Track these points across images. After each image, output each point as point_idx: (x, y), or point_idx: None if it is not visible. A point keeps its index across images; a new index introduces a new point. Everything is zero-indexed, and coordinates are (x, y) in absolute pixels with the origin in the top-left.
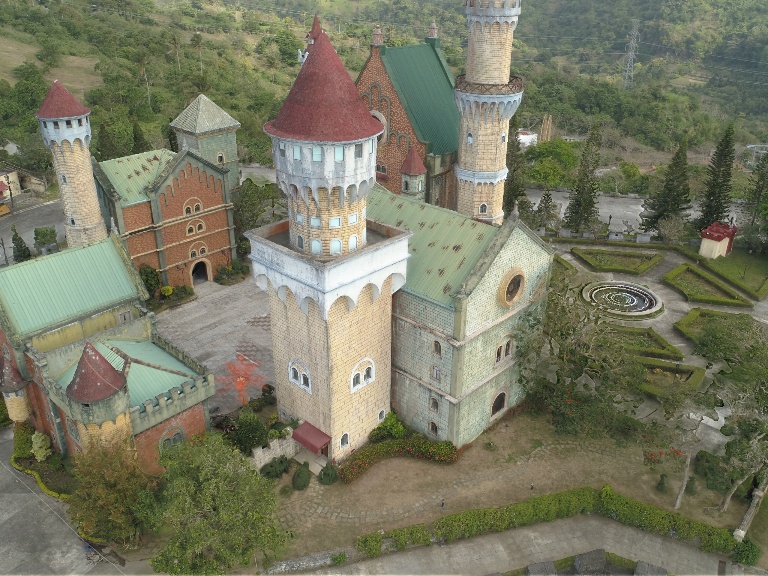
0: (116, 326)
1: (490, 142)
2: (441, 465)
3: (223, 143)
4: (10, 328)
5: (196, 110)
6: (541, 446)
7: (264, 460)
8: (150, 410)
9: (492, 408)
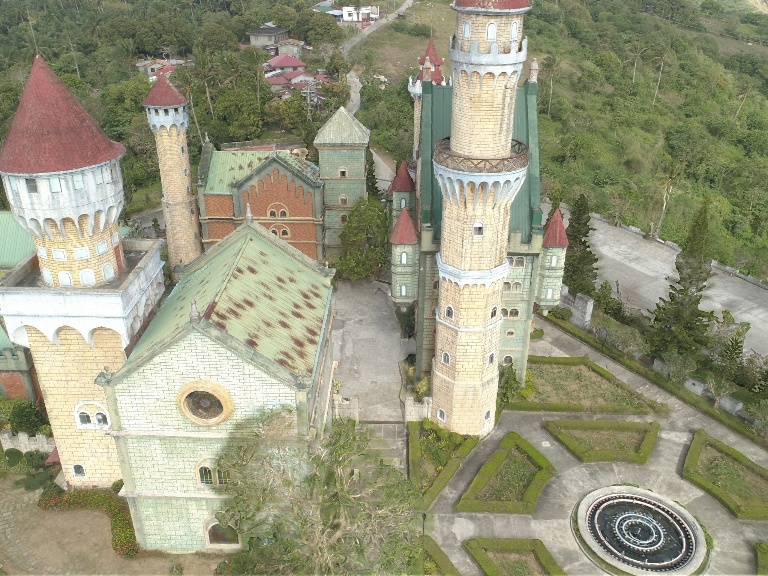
0: None
1: (456, 229)
2: None
3: (348, 158)
4: None
5: None
6: None
7: (31, 447)
8: None
9: (213, 534)
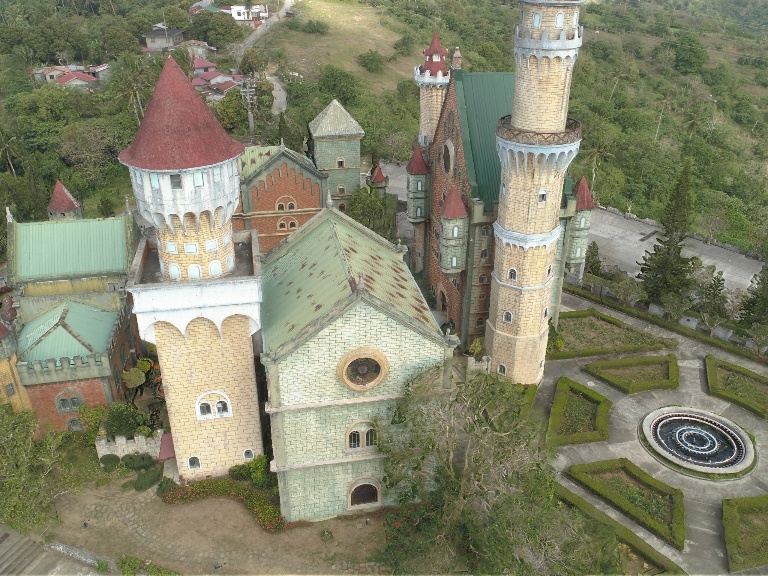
0: (86, 292)
1: (522, 198)
2: (262, 529)
3: (345, 149)
4: (12, 271)
5: (325, 114)
6: (377, 562)
7: (128, 450)
8: (38, 369)
9: (354, 496)
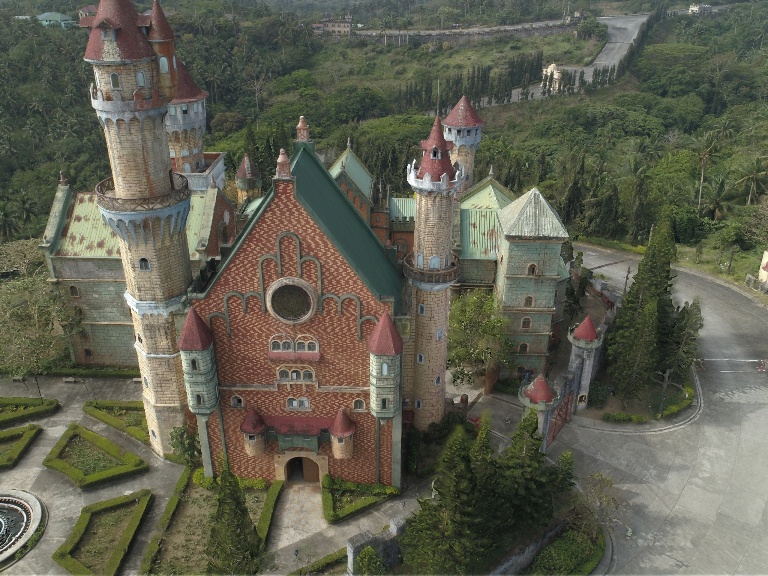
0: None
1: None
2: None
3: None
4: None
5: None
6: None
7: None
8: None
9: None
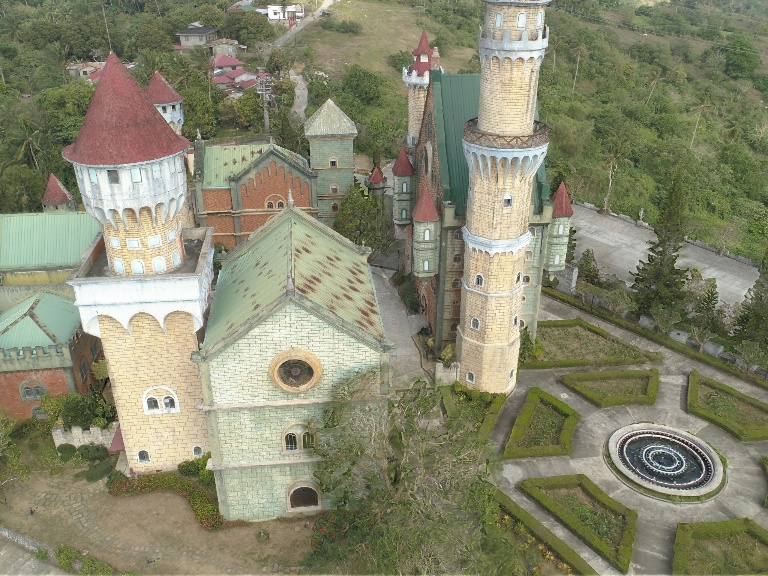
0: None
1: (487, 202)
2: None
3: (338, 149)
4: None
5: (318, 113)
6: None
7: (84, 440)
8: (1, 357)
9: (293, 498)
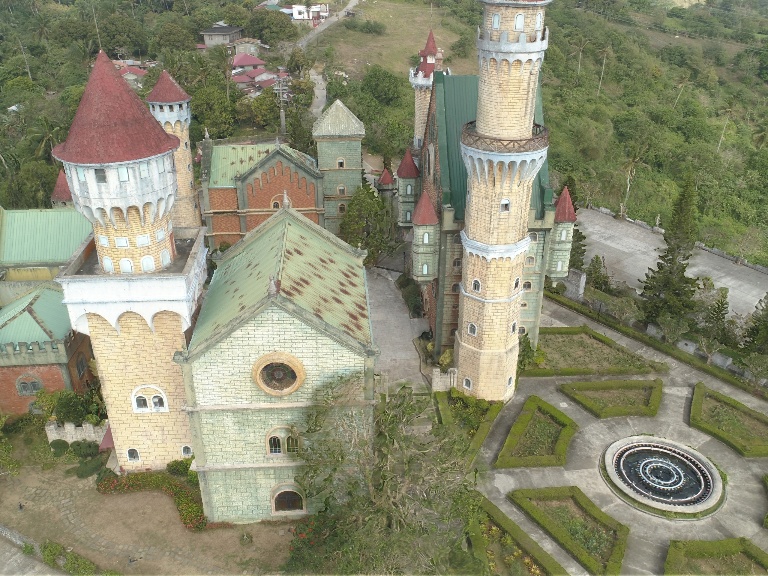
0: None
1: (484, 207)
2: None
3: (345, 150)
4: None
5: (327, 113)
6: None
7: (77, 437)
8: None
9: (278, 502)
